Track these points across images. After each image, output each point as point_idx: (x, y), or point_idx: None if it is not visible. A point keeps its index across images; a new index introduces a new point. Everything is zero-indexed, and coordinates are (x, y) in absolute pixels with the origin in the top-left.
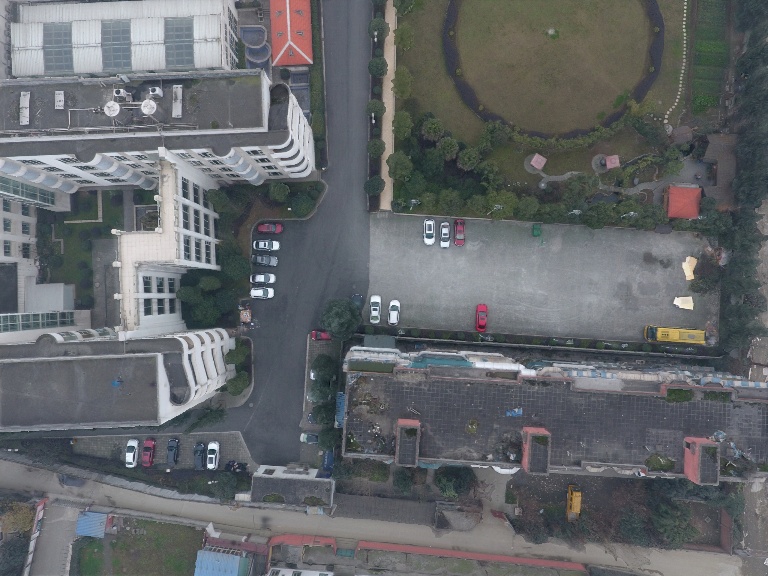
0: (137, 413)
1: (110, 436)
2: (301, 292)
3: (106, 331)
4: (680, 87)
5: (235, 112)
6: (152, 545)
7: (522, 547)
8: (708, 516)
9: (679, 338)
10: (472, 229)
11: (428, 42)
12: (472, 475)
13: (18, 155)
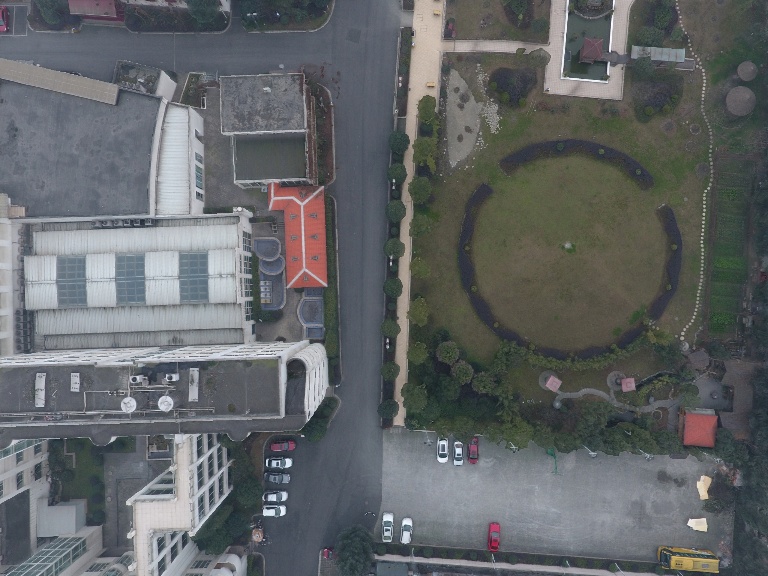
0: None
1: None
2: (313, 508)
3: (119, 572)
4: (697, 304)
5: (252, 395)
6: None
7: None
8: None
9: (693, 567)
10: (486, 445)
11: (443, 255)
12: None
13: (33, 437)
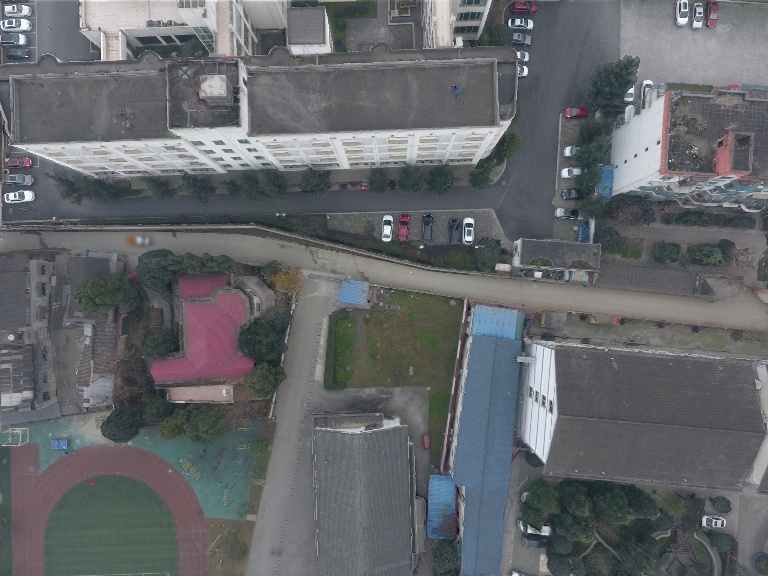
0: (470, 121)
1: (363, 213)
2: (553, 72)
3: None
4: None
5: None
6: (406, 320)
7: None
8: None
9: None
10: (722, 12)
11: None
12: (734, 245)
13: None
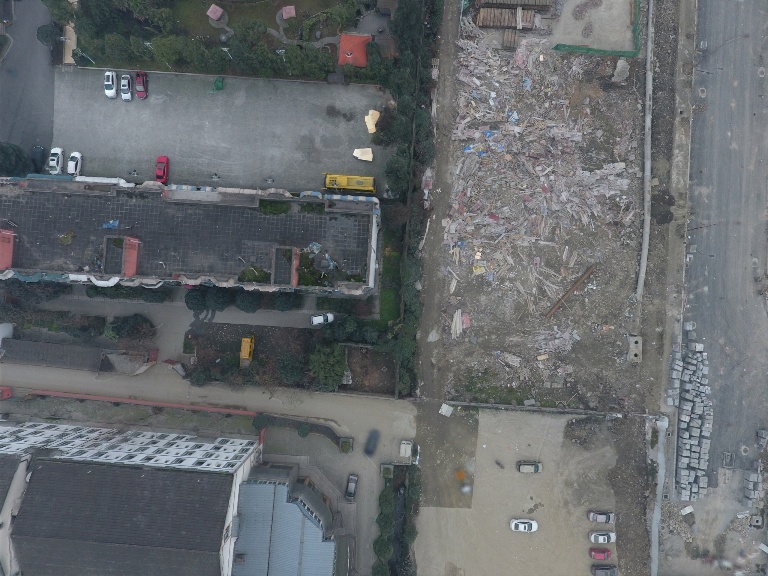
0: None
1: None
2: None
3: None
4: None
5: None
6: None
7: (198, 396)
8: (385, 366)
9: (347, 184)
10: (156, 83)
11: None
12: (139, 320)
13: None
